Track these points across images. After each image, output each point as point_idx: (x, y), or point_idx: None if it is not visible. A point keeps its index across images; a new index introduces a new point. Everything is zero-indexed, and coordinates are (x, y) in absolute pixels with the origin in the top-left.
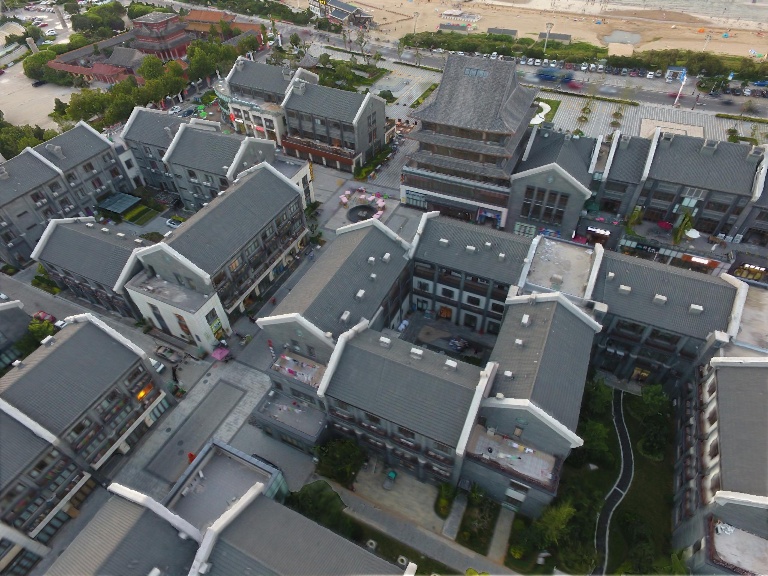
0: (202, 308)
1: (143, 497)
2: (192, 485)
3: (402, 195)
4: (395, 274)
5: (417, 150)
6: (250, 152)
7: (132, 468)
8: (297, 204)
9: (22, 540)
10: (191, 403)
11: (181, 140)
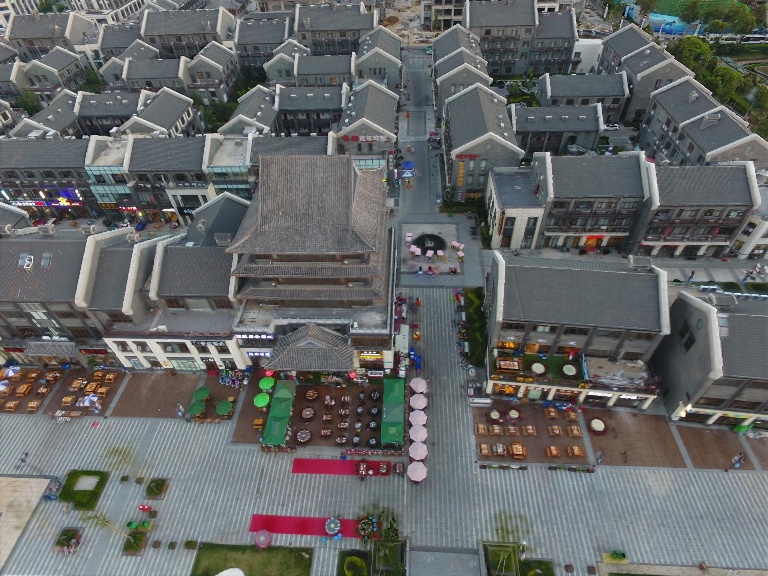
0: None
1: None
2: None
3: None
4: None
5: None
6: None
7: (430, 110)
8: None
9: None
10: (430, 126)
11: None
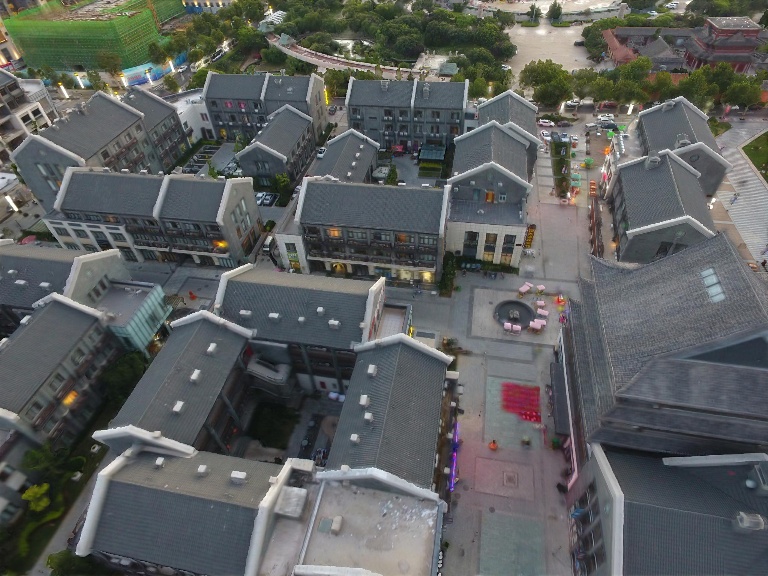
0: (283, 235)
1: (80, 257)
2: (133, 291)
3: (558, 339)
4: (323, 341)
5: None
6: (488, 177)
7: (190, 271)
8: (436, 241)
9: (130, 244)
10: None
11: (479, 133)
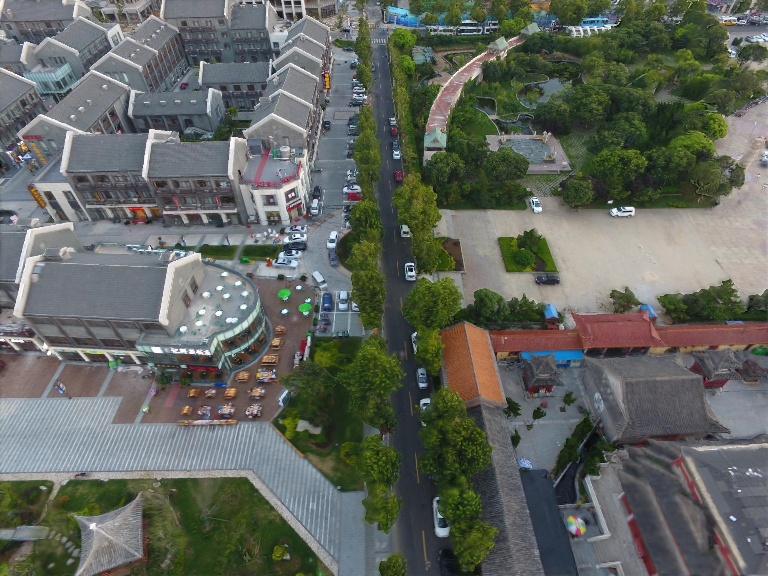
0: None
1: (49, 38)
2: None
3: None
4: None
5: None
6: None
7: None
8: None
9: None
10: None
11: None
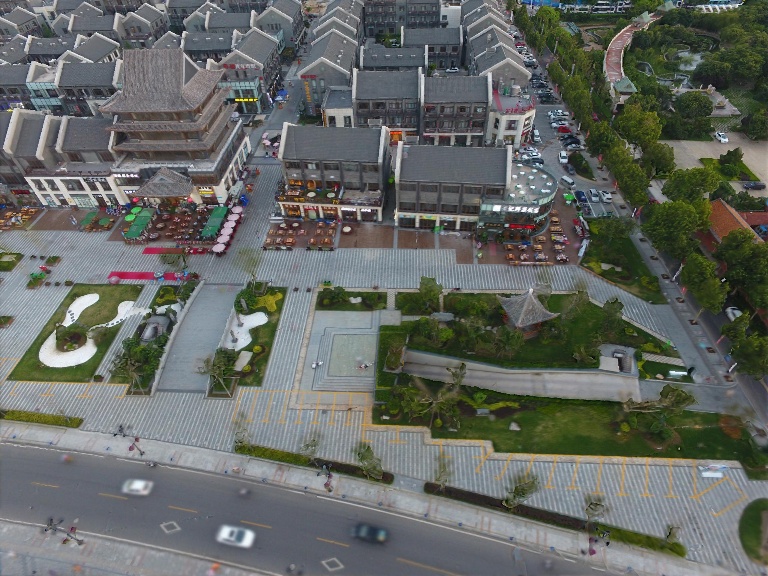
0: None
1: (272, 7)
2: None
3: None
4: None
5: (226, 106)
6: None
7: None
8: None
9: None
10: None
11: None
